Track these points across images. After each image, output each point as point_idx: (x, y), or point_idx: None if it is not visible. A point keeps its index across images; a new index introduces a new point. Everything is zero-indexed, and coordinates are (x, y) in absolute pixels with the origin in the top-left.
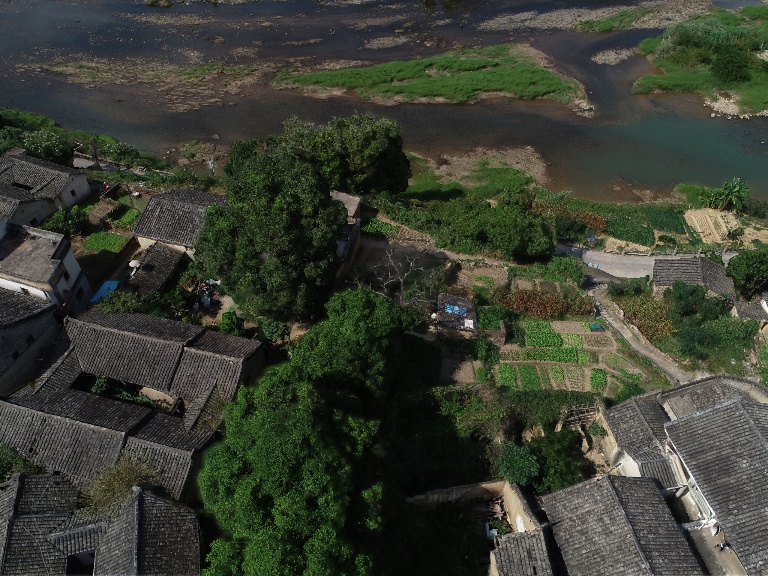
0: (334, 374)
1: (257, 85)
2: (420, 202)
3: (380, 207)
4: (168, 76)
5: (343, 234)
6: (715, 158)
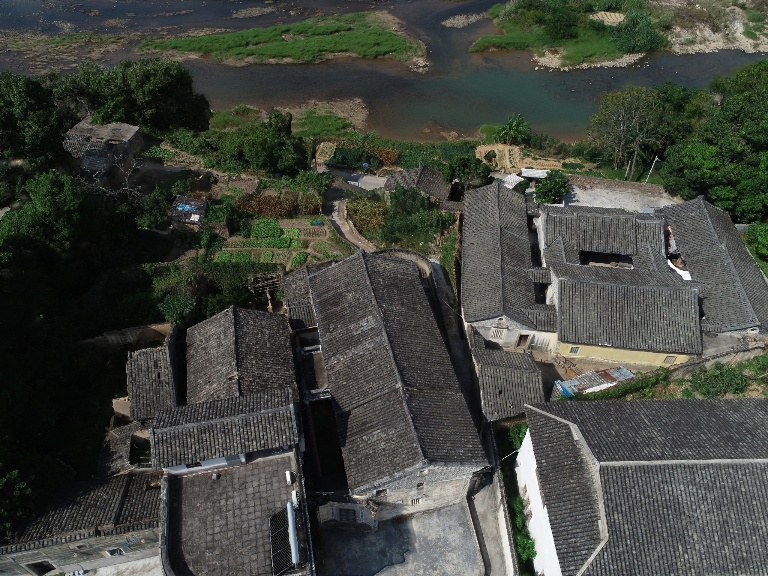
0: (14, 235)
1: (120, 51)
2: (207, 134)
3: (166, 137)
4: (36, 45)
5: (104, 152)
6: (526, 104)
